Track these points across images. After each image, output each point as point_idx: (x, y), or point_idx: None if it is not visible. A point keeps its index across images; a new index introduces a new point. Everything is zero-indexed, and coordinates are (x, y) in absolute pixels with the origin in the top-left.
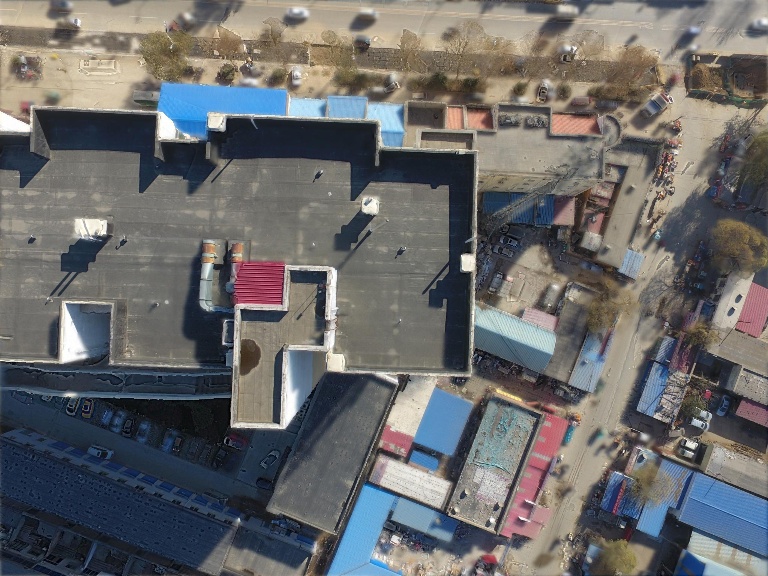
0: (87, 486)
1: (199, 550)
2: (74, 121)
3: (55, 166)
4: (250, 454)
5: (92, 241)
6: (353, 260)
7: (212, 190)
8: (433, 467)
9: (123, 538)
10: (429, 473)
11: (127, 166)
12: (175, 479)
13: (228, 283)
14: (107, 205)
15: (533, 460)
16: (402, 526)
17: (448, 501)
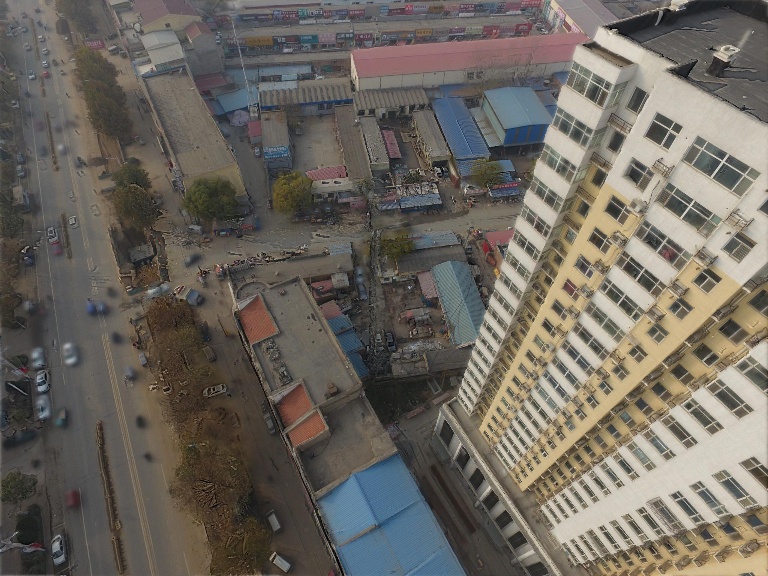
0: None
1: None
2: None
3: None
4: None
5: None
6: (762, 67)
7: None
8: None
9: None
10: None
11: None
12: None
13: None
14: None
15: None
16: None
17: None
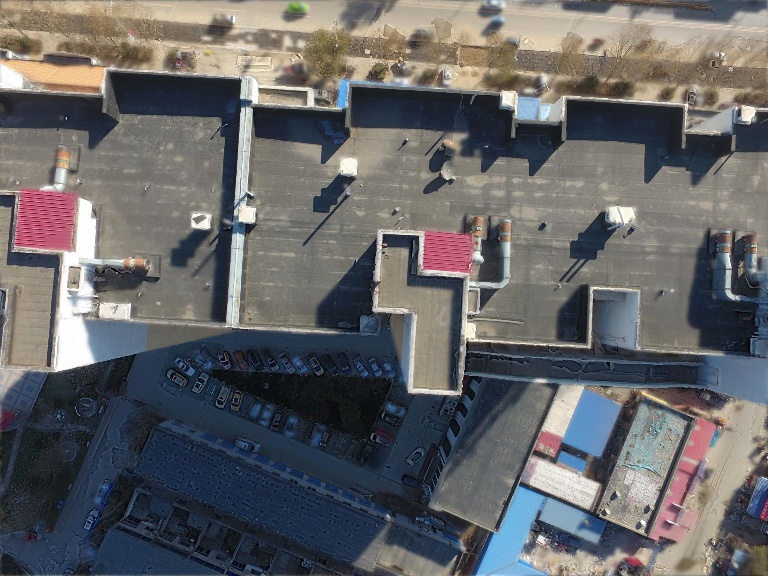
0: (245, 478)
1: (354, 545)
2: (584, 112)
3: (562, 155)
4: (395, 451)
5: (601, 229)
6: None
7: (715, 182)
8: (581, 468)
9: (279, 531)
10: (578, 474)
11: (632, 157)
12: (320, 474)
13: (767, 273)
14: (614, 194)
15: (681, 463)
16: (546, 526)
17: (598, 502)
